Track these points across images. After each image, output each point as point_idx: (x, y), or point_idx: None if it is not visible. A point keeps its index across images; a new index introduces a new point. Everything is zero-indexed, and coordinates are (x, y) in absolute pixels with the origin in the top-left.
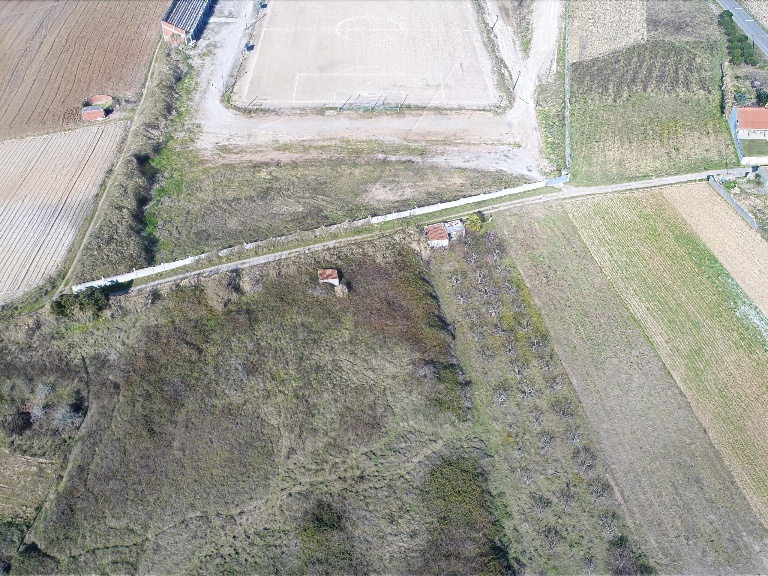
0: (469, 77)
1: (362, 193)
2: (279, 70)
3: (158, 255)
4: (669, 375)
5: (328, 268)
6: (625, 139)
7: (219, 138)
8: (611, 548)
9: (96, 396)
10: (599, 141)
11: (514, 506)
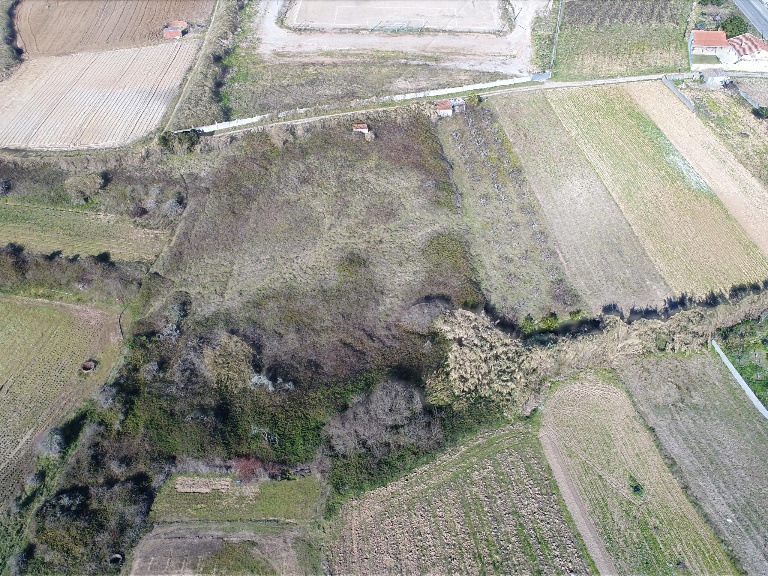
0: (479, 11)
1: (388, 83)
2: (323, 3)
3: (232, 117)
4: (609, 194)
5: (360, 123)
6: (601, 53)
7: (275, 47)
8: (553, 285)
9: (193, 195)
10: (579, 54)
11: (487, 262)
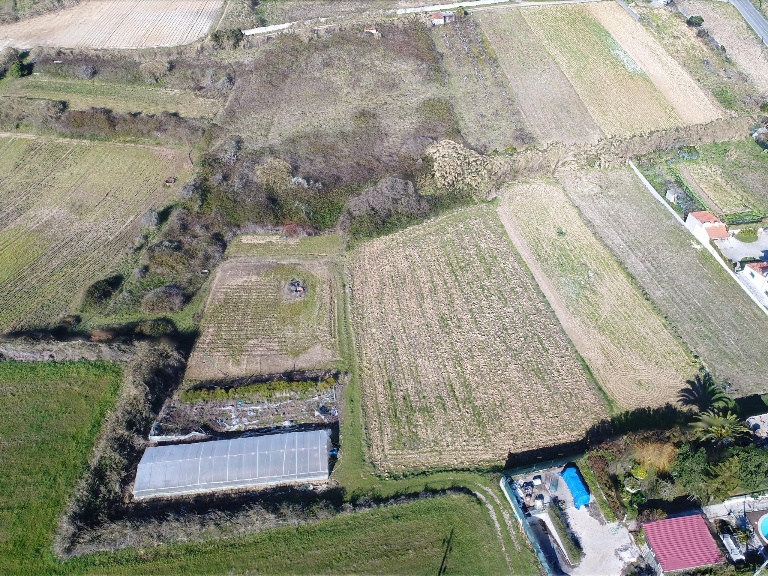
0: None
1: (392, 4)
2: None
3: None
4: (564, 75)
5: (370, 27)
6: None
7: None
8: (515, 131)
9: (240, 75)
10: None
11: (467, 117)
